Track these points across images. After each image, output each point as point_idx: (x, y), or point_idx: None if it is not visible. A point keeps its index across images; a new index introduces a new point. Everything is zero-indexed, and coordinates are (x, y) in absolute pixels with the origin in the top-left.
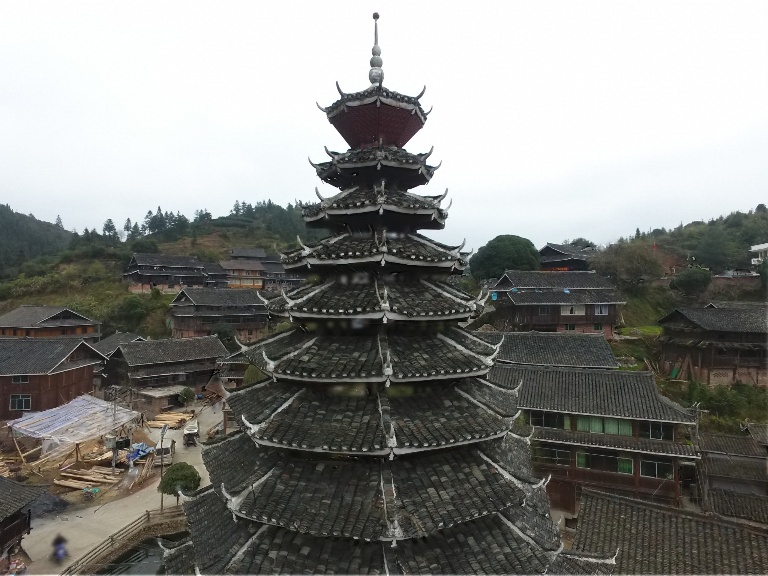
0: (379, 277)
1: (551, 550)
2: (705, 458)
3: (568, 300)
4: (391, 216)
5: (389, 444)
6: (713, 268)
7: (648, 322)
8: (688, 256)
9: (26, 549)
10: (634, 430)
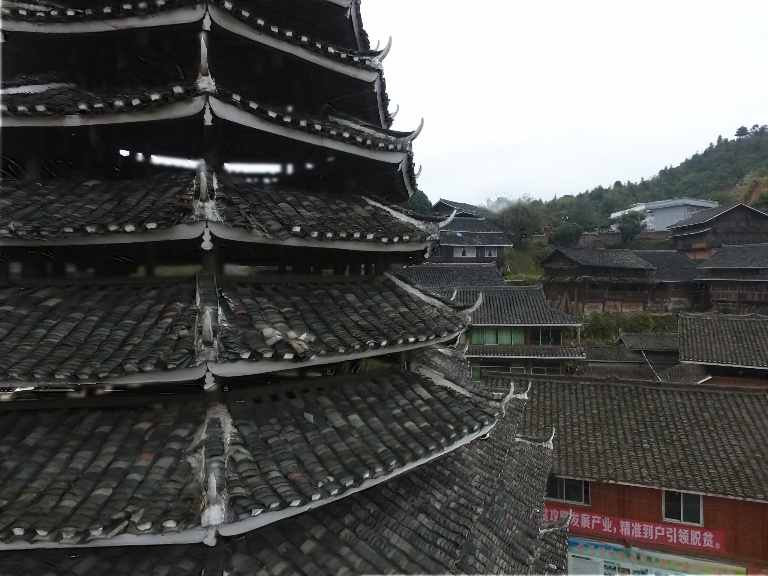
0: None
1: (465, 308)
2: (586, 367)
3: (460, 242)
4: None
5: (200, 83)
6: (583, 226)
7: (530, 271)
8: (563, 215)
9: None
10: (526, 338)
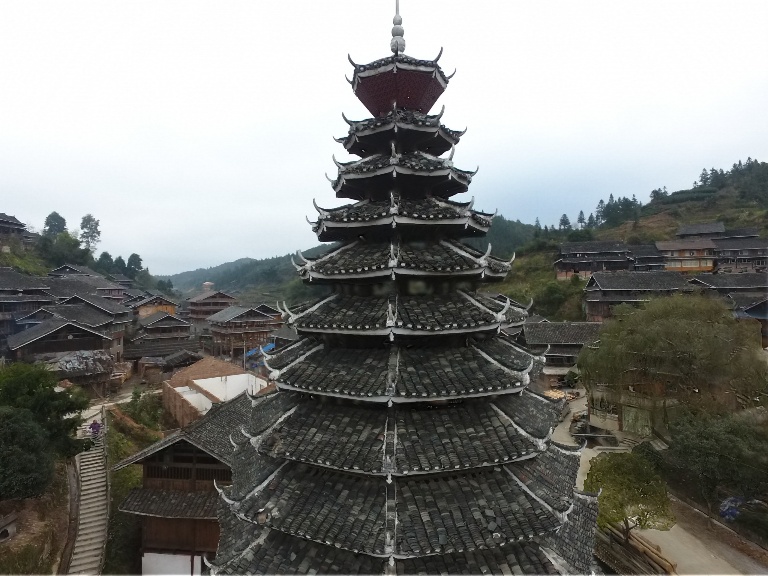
0: None
1: None
2: None
3: None
4: (362, 183)
5: (269, 376)
6: None
7: None
8: None
9: None
10: None
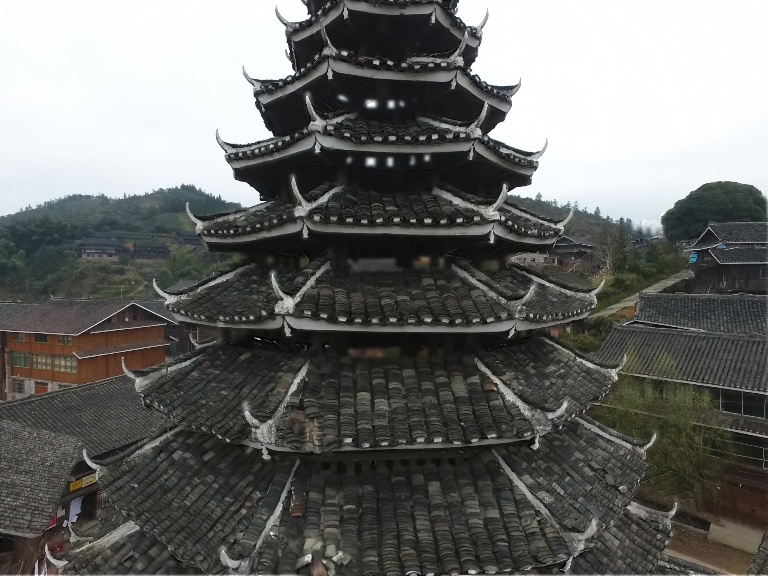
0: (343, 108)
1: (574, 530)
2: None
3: None
4: (369, 25)
5: (276, 308)
6: None
7: None
8: None
9: None
10: None
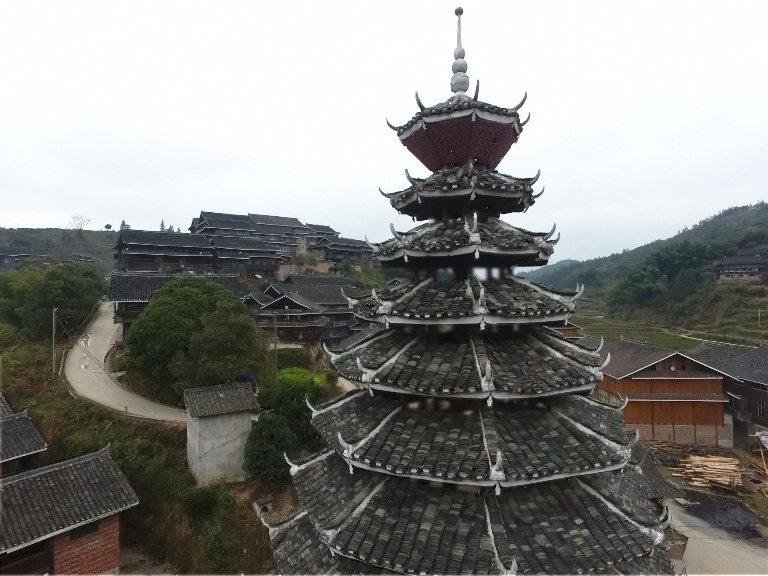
0: None
1: None
2: None
3: None
4: (396, 264)
5: None
6: None
7: None
8: None
9: (687, 546)
10: None
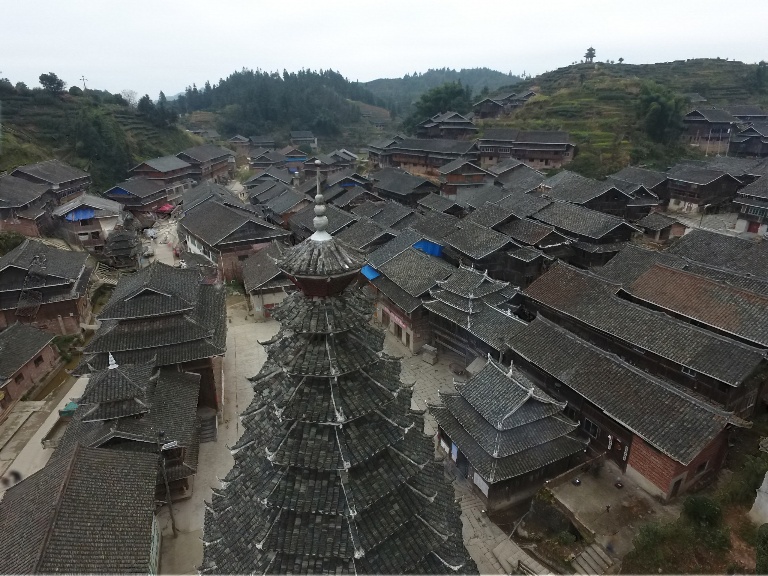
0: None
1: None
2: None
3: None
4: None
5: None
6: None
7: None
8: None
9: None
10: None
